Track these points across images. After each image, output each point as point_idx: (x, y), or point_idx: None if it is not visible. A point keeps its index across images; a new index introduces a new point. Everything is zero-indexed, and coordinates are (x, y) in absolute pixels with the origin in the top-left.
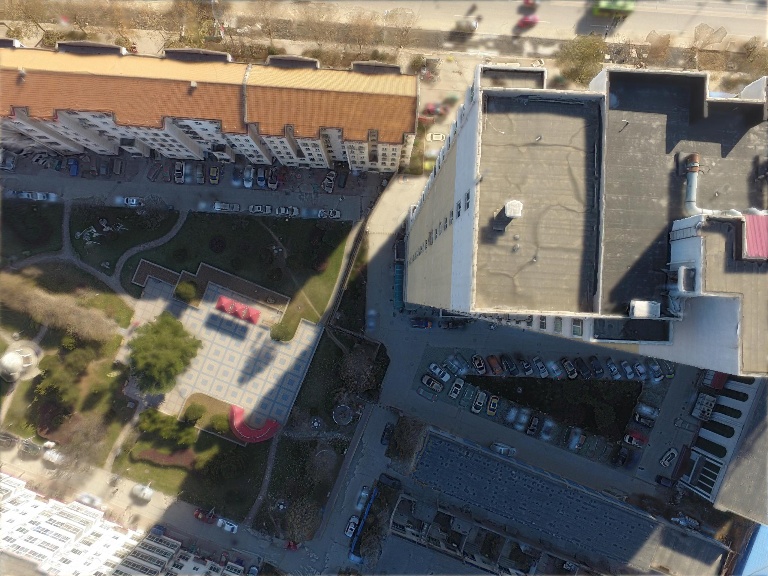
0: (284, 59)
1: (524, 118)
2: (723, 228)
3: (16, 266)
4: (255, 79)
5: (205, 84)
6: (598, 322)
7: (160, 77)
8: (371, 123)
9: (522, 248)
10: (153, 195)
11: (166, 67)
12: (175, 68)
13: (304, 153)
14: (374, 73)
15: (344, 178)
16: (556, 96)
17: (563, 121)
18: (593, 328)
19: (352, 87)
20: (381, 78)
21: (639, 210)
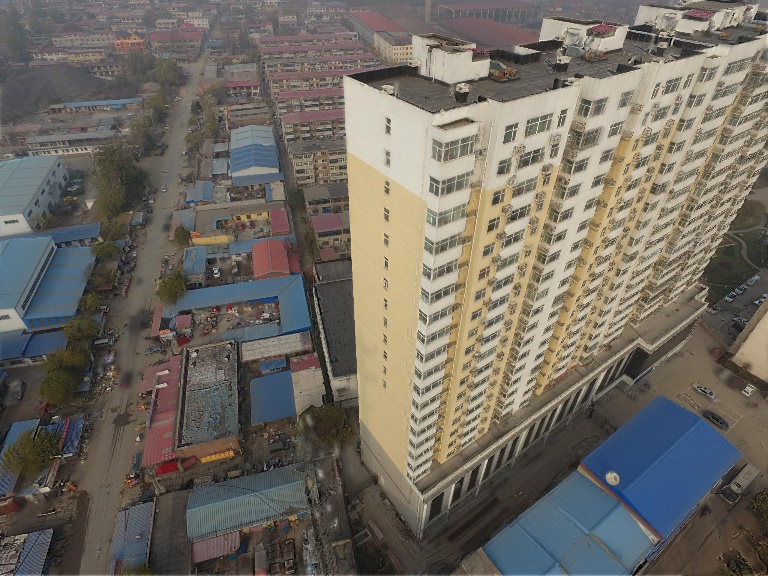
0: None
1: None
2: None
3: (764, 212)
4: None
5: None
6: None
7: None
8: None
9: None
10: None
11: None
12: None
13: None
14: None
15: (742, 326)
16: None
17: None
18: None
19: None
20: None
21: None
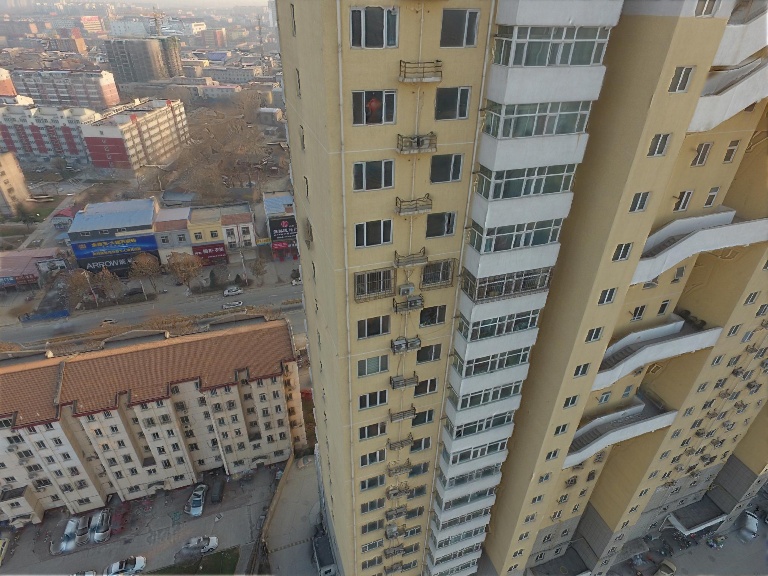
0: (124, 339)
1: None
2: None
3: None
4: (80, 358)
5: (3, 376)
6: None
7: None
8: (237, 362)
9: None
10: None
11: None
12: None
13: (152, 450)
14: (235, 327)
15: (219, 486)
16: None
17: None
18: None
19: (209, 336)
20: (244, 327)
21: None
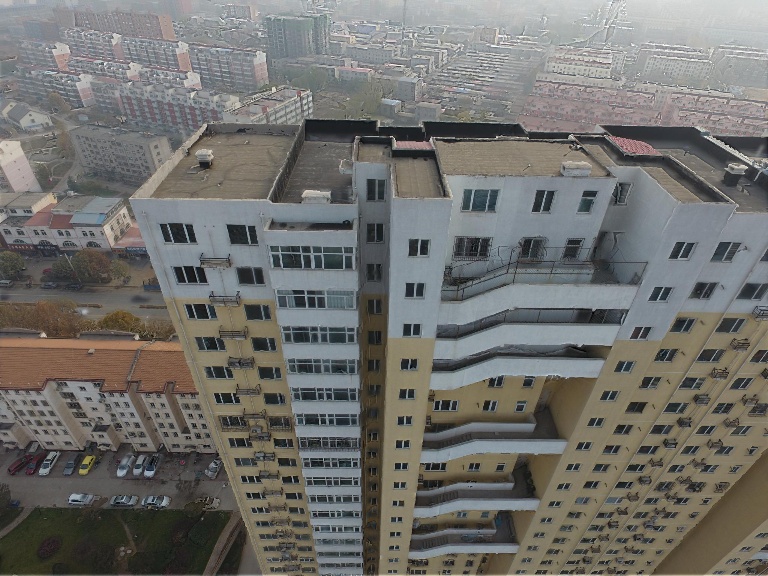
0: None
1: (239, 138)
2: (380, 147)
3: None
4: (152, 347)
5: (102, 351)
6: (279, 225)
7: (63, 347)
8: None
9: (209, 180)
10: (0, 482)
11: (74, 343)
12: (82, 343)
13: (188, 424)
14: None
15: None
16: (266, 129)
17: (270, 139)
18: (269, 224)
19: None
20: None
21: (331, 173)
